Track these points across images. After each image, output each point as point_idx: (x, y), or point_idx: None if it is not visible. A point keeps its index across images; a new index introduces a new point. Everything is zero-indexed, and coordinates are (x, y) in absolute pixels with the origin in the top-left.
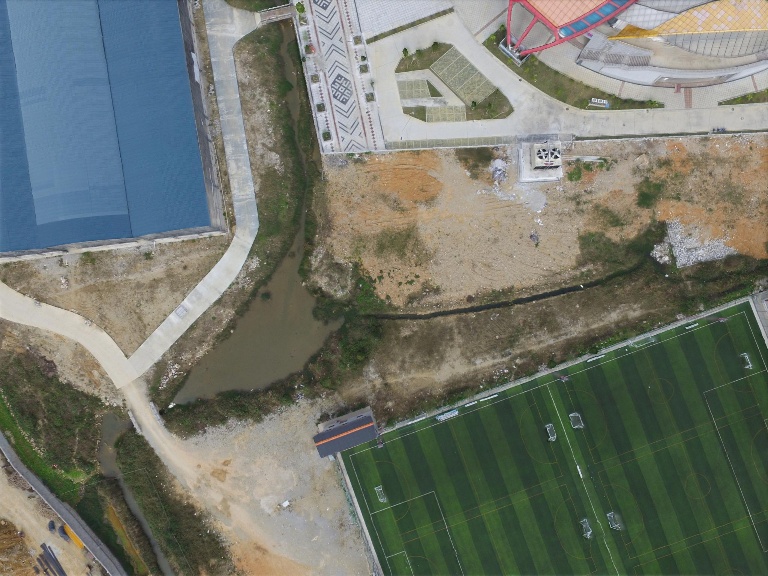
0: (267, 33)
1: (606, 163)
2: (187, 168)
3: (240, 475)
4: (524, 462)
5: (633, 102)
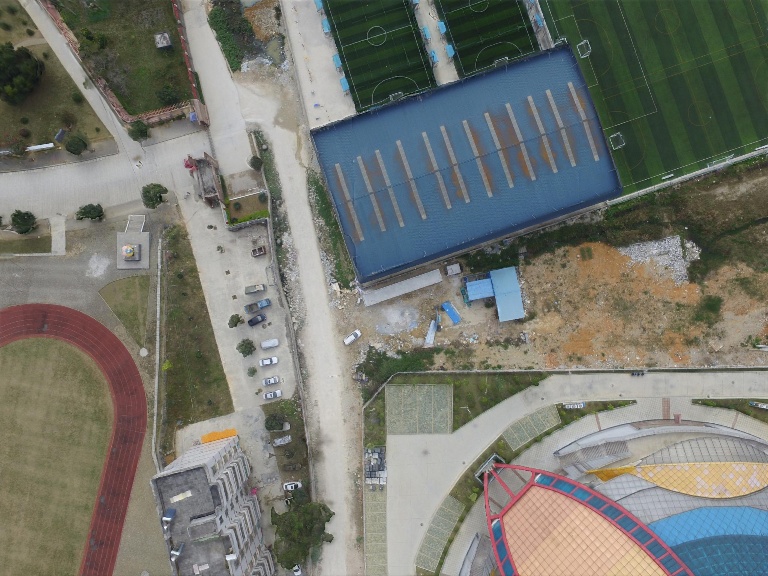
0: None
1: (753, 343)
2: None
3: None
4: None
5: (725, 406)
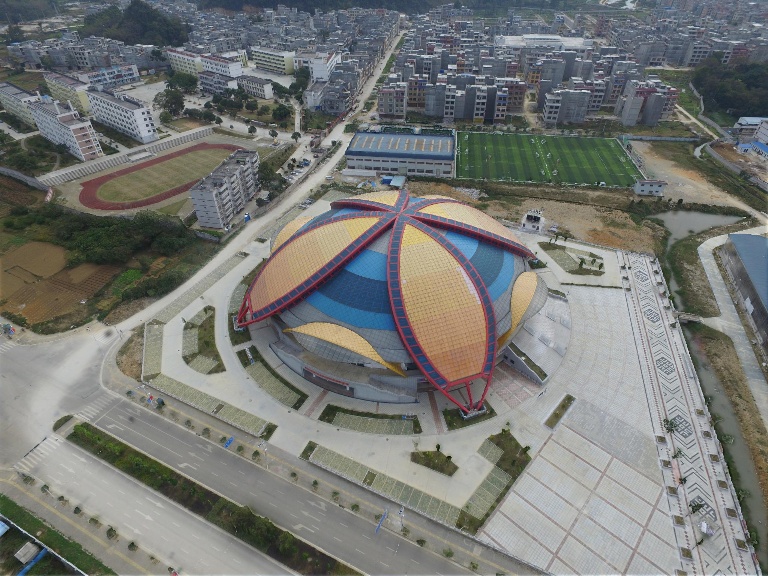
0: None
1: None
2: None
3: (704, 194)
4: None
5: None
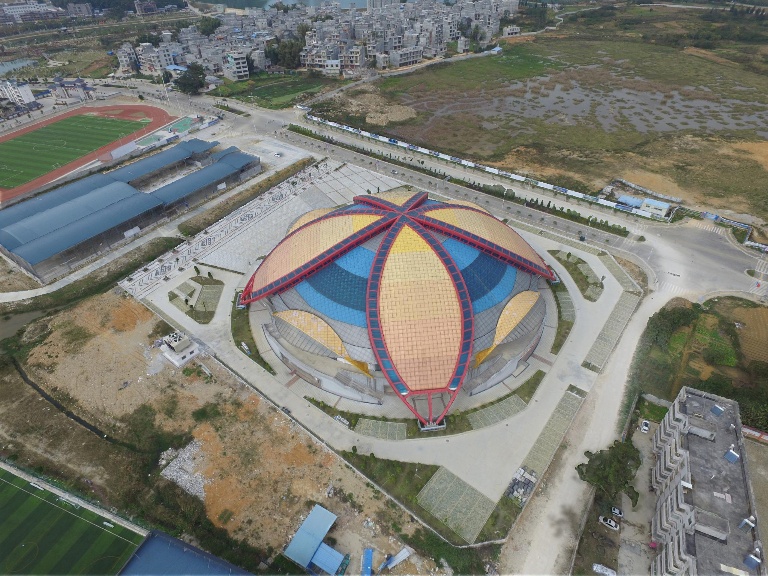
0: (174, 241)
1: (210, 379)
2: (63, 245)
3: None
4: None
5: None
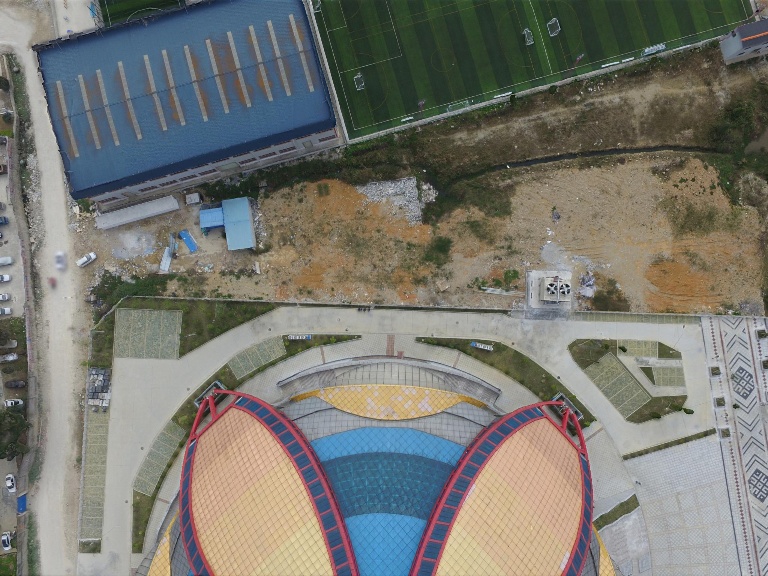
0: None
1: (479, 285)
2: None
3: None
4: (579, 3)
5: (447, 345)
